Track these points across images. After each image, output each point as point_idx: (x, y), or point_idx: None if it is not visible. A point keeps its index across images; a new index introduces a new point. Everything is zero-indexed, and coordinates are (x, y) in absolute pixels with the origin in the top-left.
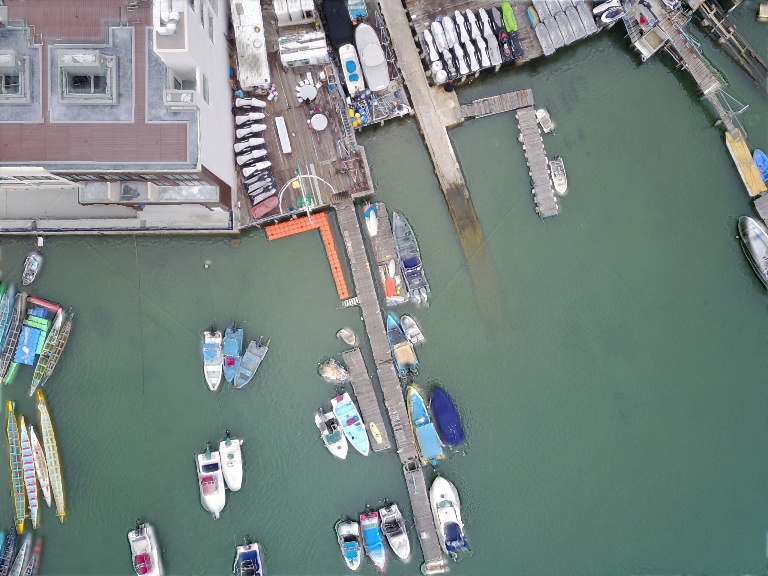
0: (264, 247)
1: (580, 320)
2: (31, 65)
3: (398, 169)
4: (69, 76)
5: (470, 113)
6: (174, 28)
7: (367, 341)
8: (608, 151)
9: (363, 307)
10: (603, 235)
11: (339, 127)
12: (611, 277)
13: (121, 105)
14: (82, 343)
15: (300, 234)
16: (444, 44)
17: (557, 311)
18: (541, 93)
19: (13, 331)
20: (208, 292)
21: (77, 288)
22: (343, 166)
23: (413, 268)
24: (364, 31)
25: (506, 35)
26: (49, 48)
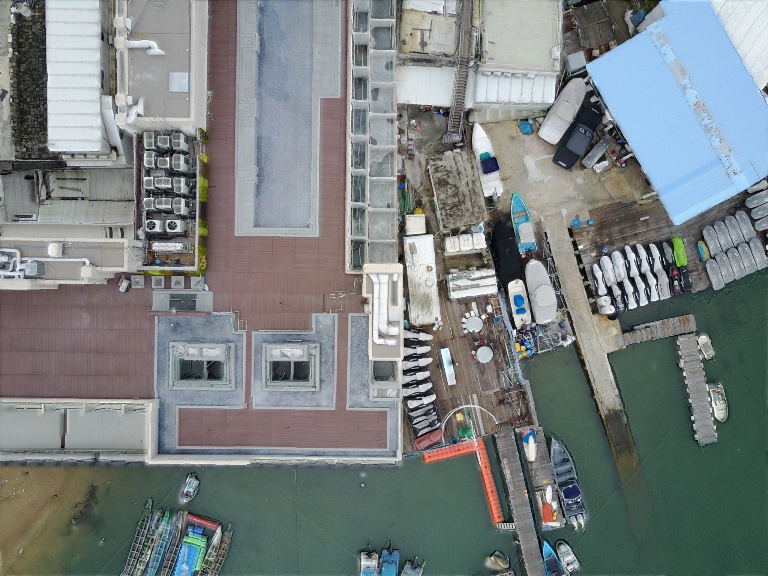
0: (420, 468)
1: (733, 544)
2: (235, 351)
3: (555, 391)
4: (272, 362)
5: (632, 341)
6: (394, 344)
7: (521, 564)
8: (767, 376)
9: (520, 534)
10: (759, 460)
11: (503, 357)
12: (767, 503)
13: (322, 391)
14: (240, 559)
15: (457, 456)
16: (613, 279)
17: (711, 535)
18: (702, 317)
19: (174, 547)
20: (364, 511)
21: (235, 504)
22: (507, 399)
23: (573, 500)
24: (535, 269)
25: (677, 273)
26: (253, 334)
